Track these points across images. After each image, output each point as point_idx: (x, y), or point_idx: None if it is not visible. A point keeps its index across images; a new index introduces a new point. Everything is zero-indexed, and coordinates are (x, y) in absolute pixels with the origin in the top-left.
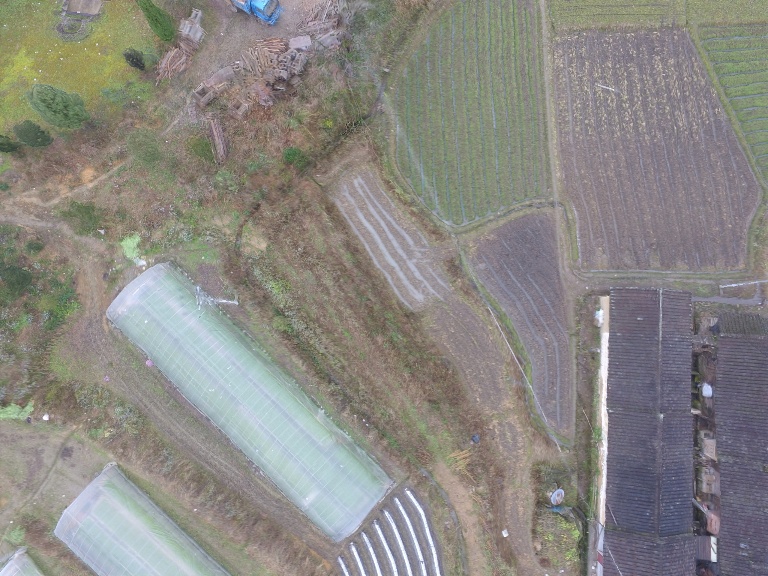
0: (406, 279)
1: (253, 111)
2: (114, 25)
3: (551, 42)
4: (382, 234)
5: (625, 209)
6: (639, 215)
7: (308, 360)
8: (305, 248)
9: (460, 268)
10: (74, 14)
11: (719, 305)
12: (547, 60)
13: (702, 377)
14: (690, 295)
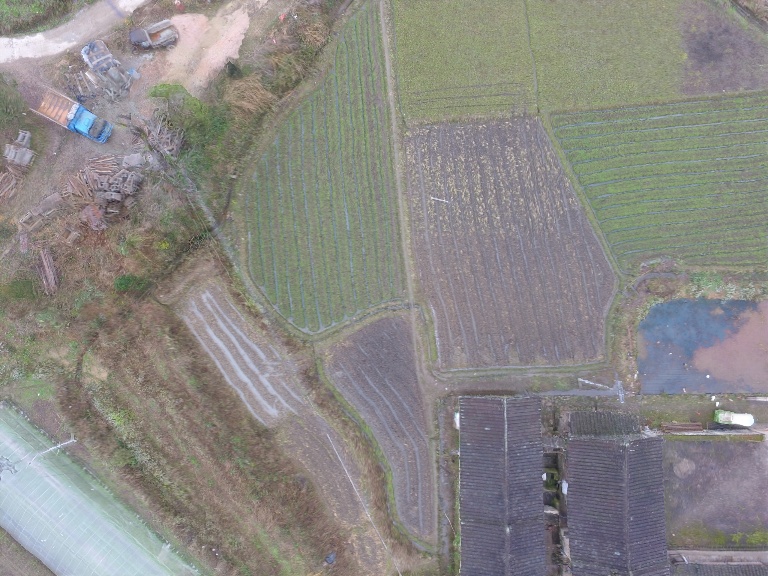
0: (259, 395)
1: (86, 236)
2: None
3: (403, 138)
4: (232, 350)
5: (483, 305)
6: (497, 311)
7: (152, 493)
8: (146, 377)
9: (316, 378)
10: None
11: (578, 398)
12: (398, 157)
13: (561, 474)
14: (539, 399)
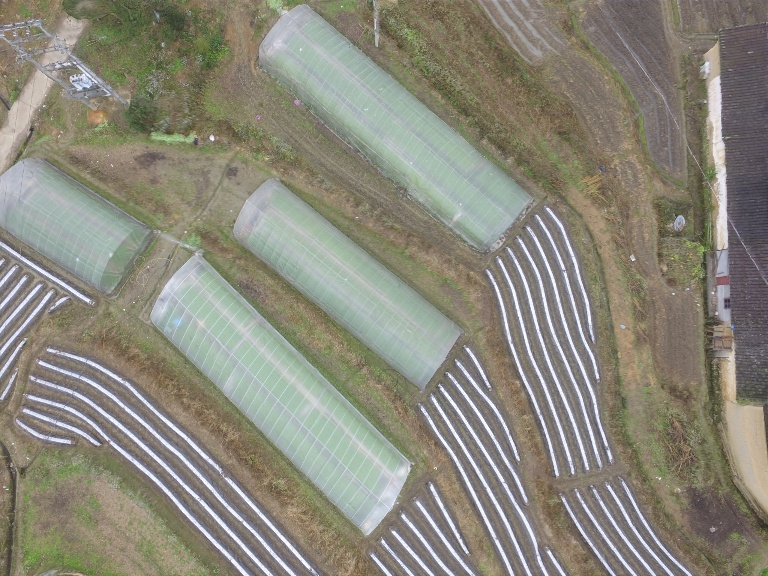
0: (524, 37)
1: None
2: None
3: None
4: None
5: None
6: None
7: (445, 97)
8: None
9: (572, 30)
10: None
11: None
12: None
13: None
14: None
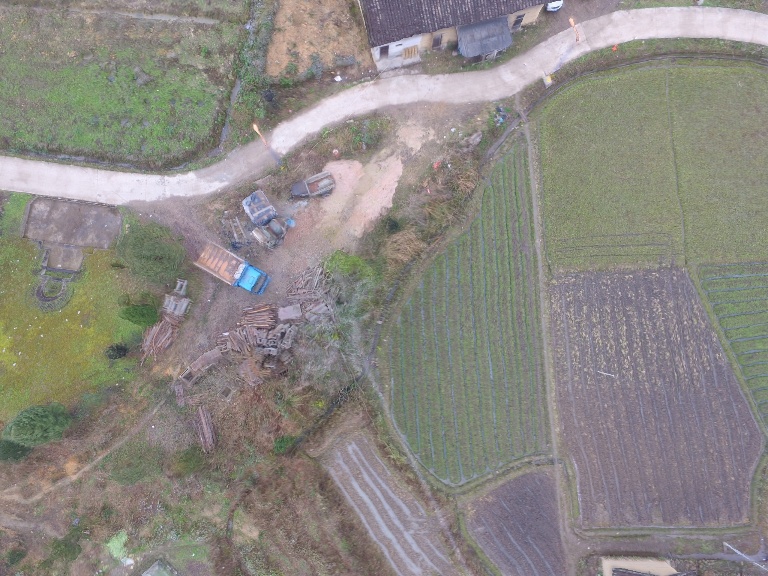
0: (404, 552)
1: (242, 391)
2: (96, 285)
3: (548, 286)
4: (378, 505)
5: (626, 461)
6: (640, 467)
7: None
8: (299, 538)
9: (459, 534)
10: (54, 271)
11: (723, 563)
12: (544, 307)
13: None
14: (694, 575)
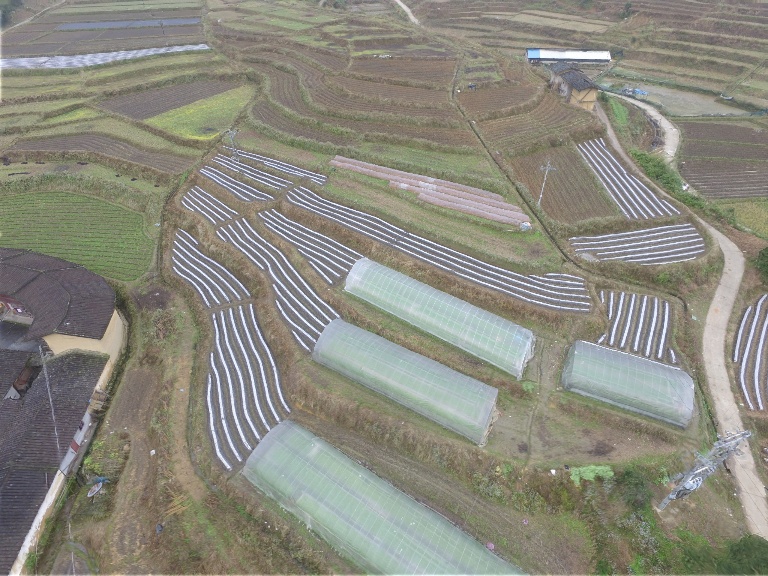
0: None
1: None
2: None
3: None
4: None
5: None
6: None
7: None
8: None
9: None
10: None
11: None
12: None
13: None
14: None
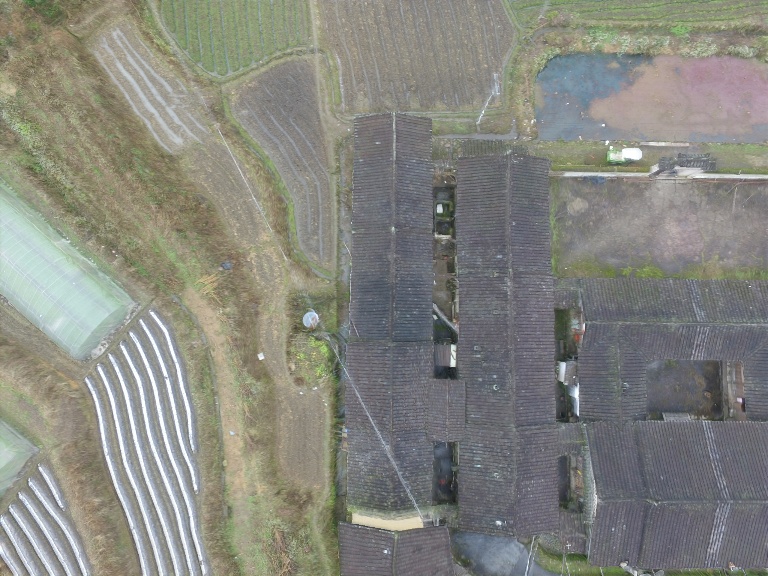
0: (165, 124)
1: None
2: None
3: None
4: (141, 82)
5: (386, 55)
6: (400, 60)
7: (55, 196)
8: (52, 90)
9: (222, 114)
10: None
11: None
12: None
13: None
14: (430, 121)
